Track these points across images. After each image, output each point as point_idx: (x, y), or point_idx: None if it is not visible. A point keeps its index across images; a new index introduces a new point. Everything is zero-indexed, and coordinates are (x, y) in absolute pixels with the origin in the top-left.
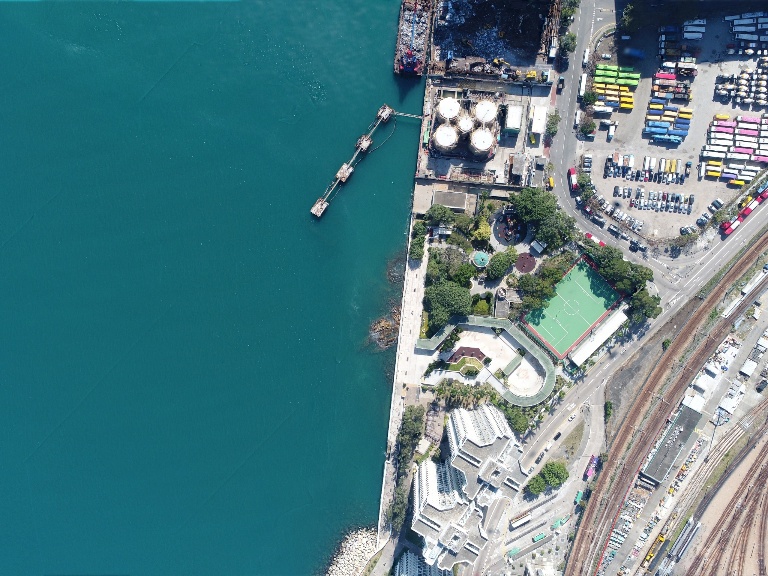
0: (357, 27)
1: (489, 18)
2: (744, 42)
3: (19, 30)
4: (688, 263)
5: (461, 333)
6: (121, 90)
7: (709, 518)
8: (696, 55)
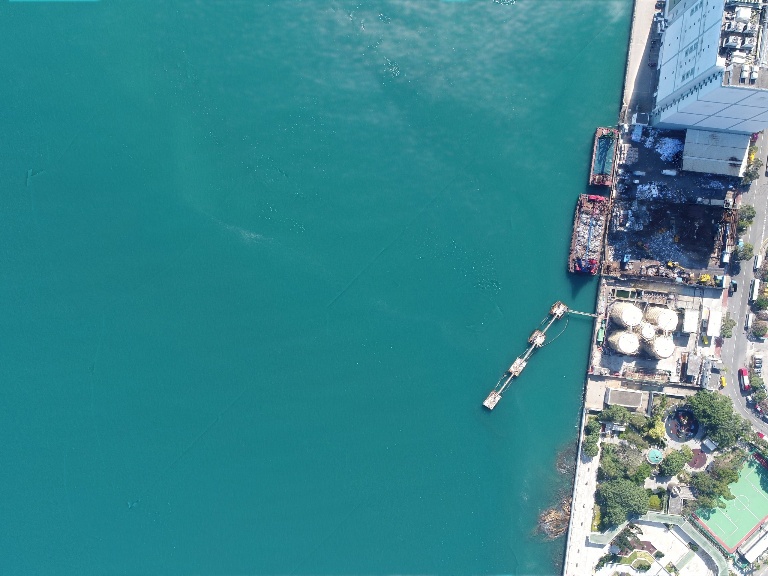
0: (531, 225)
1: (663, 222)
2: None
3: (182, 210)
4: None
5: None
6: (309, 295)
7: None
8: None
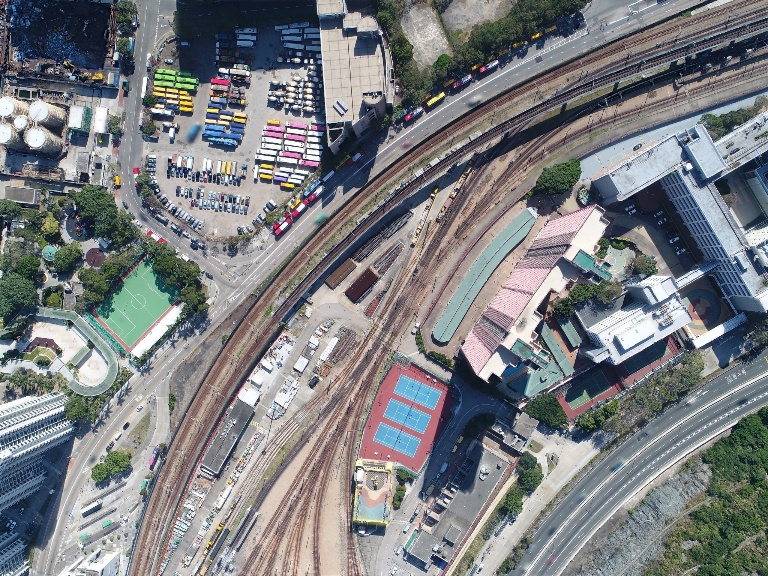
0: None
1: (60, 22)
2: (293, 51)
3: None
4: (245, 262)
5: (37, 324)
6: None
7: (267, 509)
8: (248, 62)
